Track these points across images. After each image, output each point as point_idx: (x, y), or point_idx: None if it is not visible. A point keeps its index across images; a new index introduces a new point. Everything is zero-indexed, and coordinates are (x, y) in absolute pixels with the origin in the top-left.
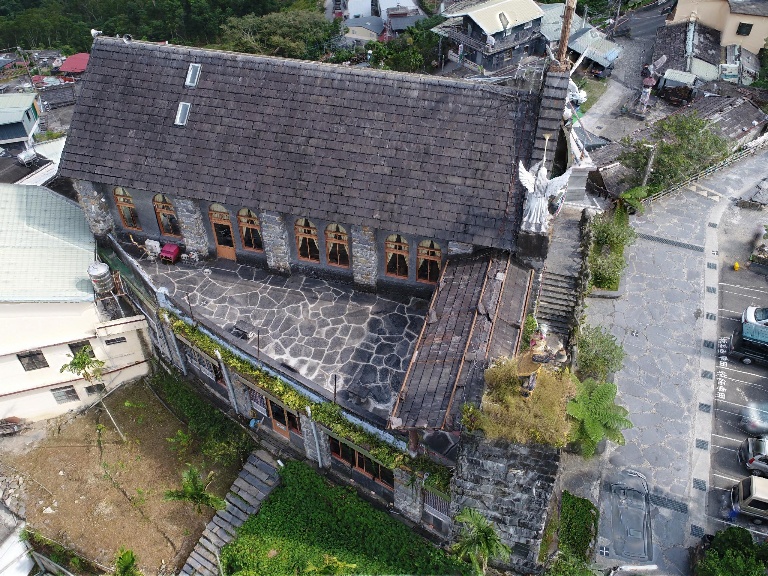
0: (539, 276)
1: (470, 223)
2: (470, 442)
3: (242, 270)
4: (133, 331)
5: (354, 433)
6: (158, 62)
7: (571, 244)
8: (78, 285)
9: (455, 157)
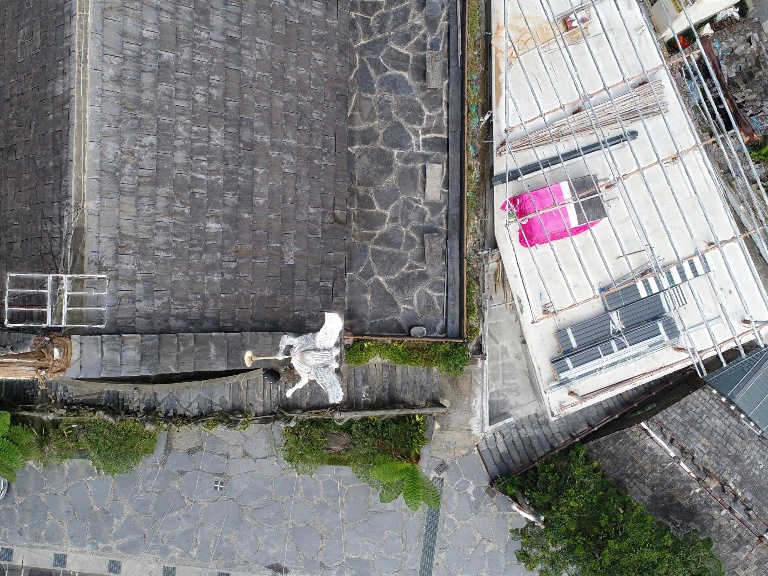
0: None
1: None
2: None
3: None
4: None
5: None
6: None
7: (229, 396)
8: None
9: (7, 200)
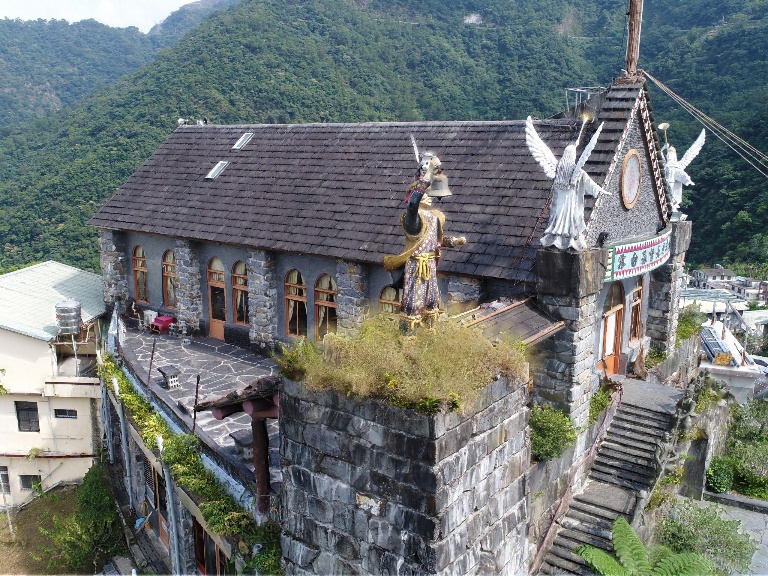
0: (573, 335)
1: (477, 251)
2: (293, 419)
3: (224, 347)
4: (87, 404)
5: (198, 480)
6: (220, 136)
7: None
8: (47, 327)
9: (479, 186)
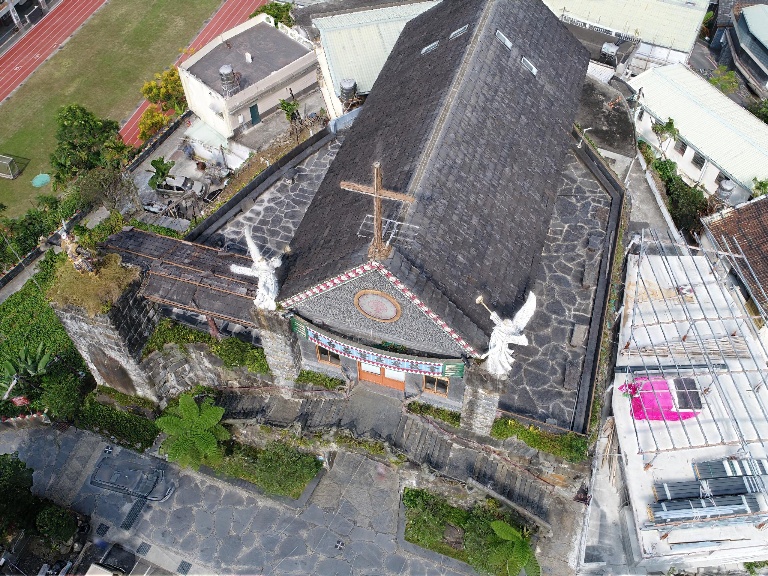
0: None
1: (292, 257)
2: None
3: None
4: None
5: None
6: None
7: None
8: None
9: None
